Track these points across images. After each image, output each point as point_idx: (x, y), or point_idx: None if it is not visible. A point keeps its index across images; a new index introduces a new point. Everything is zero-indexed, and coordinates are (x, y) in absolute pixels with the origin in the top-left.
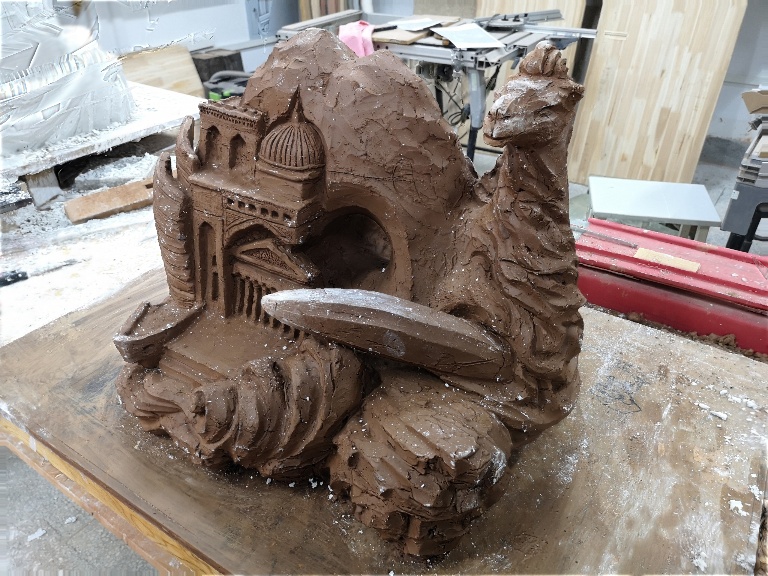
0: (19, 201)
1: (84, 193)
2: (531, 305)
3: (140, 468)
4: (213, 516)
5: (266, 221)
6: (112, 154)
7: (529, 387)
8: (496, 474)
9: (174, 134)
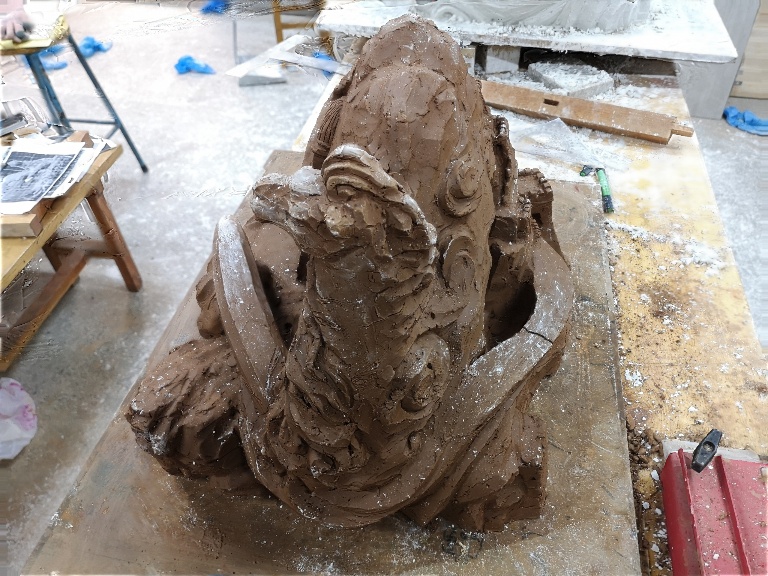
0: None
1: (524, 80)
2: None
3: None
4: (193, 323)
5: None
6: (601, 57)
7: None
8: (153, 448)
9: None
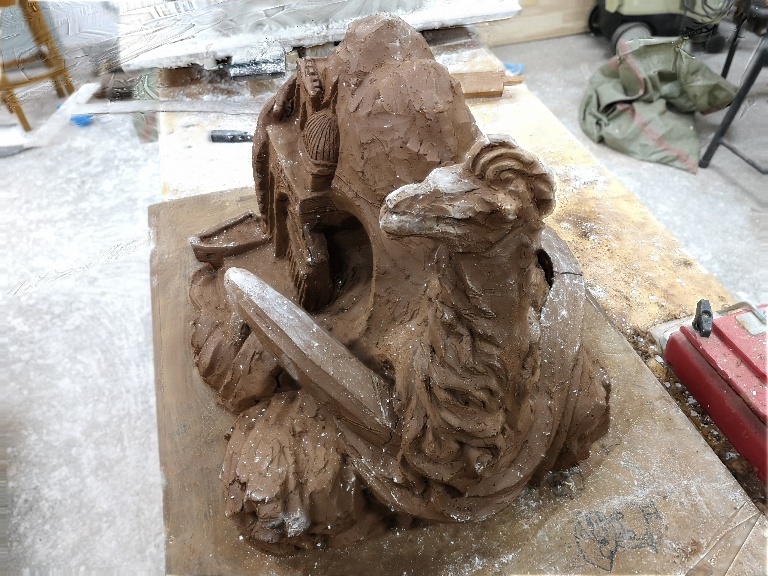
0: (275, 72)
1: None
2: (425, 405)
3: (179, 341)
4: (185, 407)
5: (289, 195)
6: None
7: (405, 477)
8: (289, 531)
9: (466, 29)
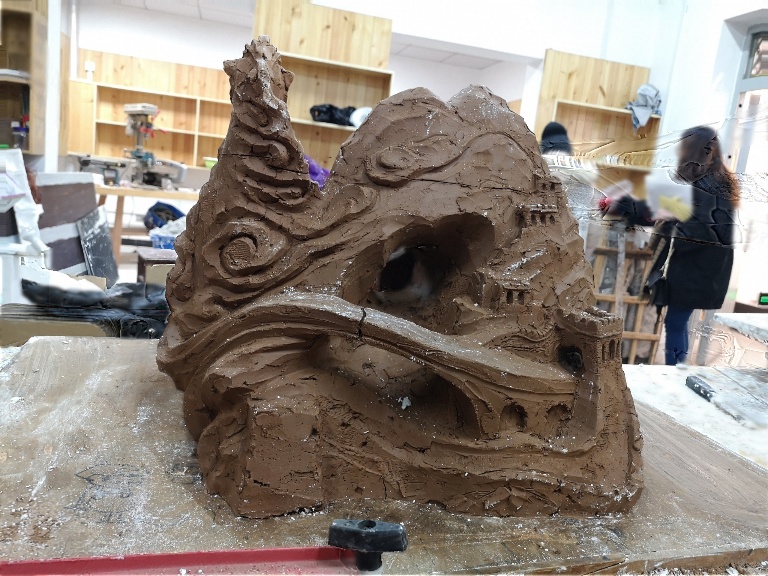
0: None
1: None
2: None
3: None
4: None
5: None
6: None
7: None
8: None
9: None
